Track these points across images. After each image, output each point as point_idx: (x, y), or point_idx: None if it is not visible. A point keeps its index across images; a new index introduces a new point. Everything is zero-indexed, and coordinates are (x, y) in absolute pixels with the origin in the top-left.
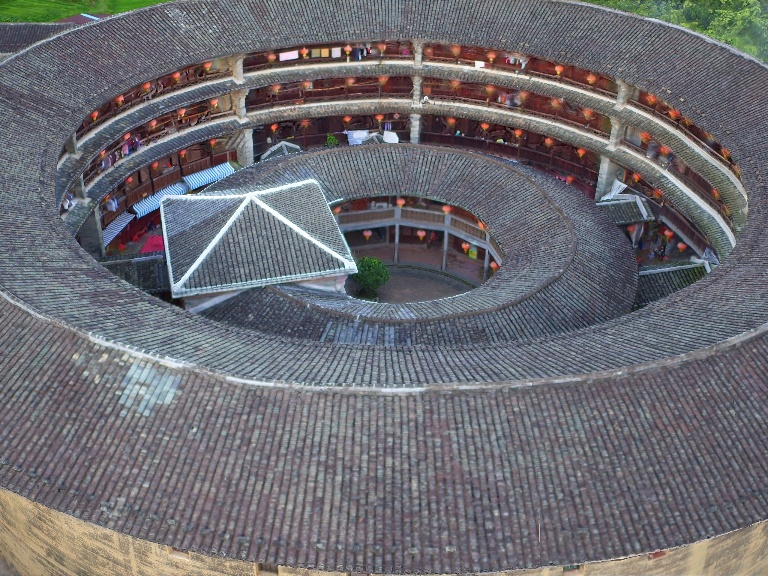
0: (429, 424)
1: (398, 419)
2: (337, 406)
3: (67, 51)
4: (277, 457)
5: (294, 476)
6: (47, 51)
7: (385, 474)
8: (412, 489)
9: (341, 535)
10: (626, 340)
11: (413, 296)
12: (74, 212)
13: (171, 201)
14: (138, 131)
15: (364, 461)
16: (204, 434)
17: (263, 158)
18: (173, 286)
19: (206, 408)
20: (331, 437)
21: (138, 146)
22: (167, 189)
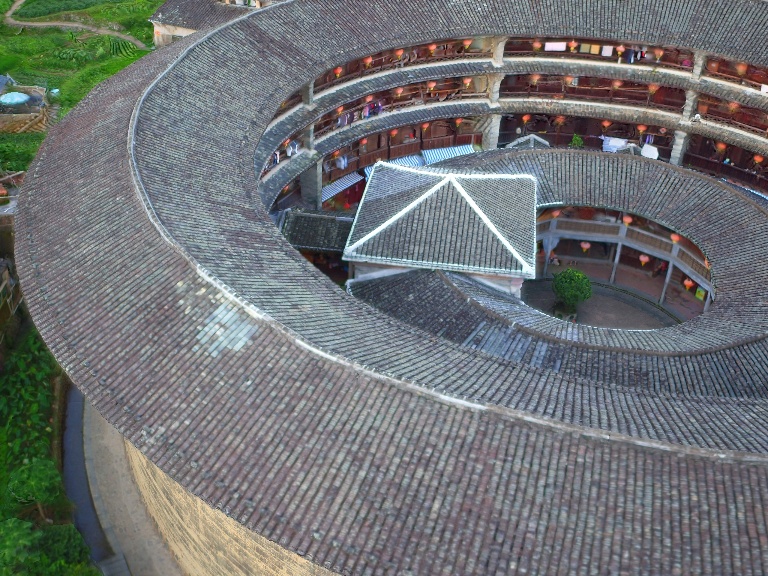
0: (477, 446)
1: (446, 431)
2: (389, 399)
3: (331, 7)
4: (312, 433)
5: (320, 457)
6: (312, 4)
7: (410, 484)
8: (432, 509)
9: (342, 532)
10: (767, 423)
11: (616, 322)
12: (297, 160)
13: (382, 168)
14: (384, 96)
15: (394, 464)
16: (255, 389)
17: (508, 147)
18: (346, 248)
19: (267, 364)
20: (371, 429)
21: (380, 111)
22: (403, 159)
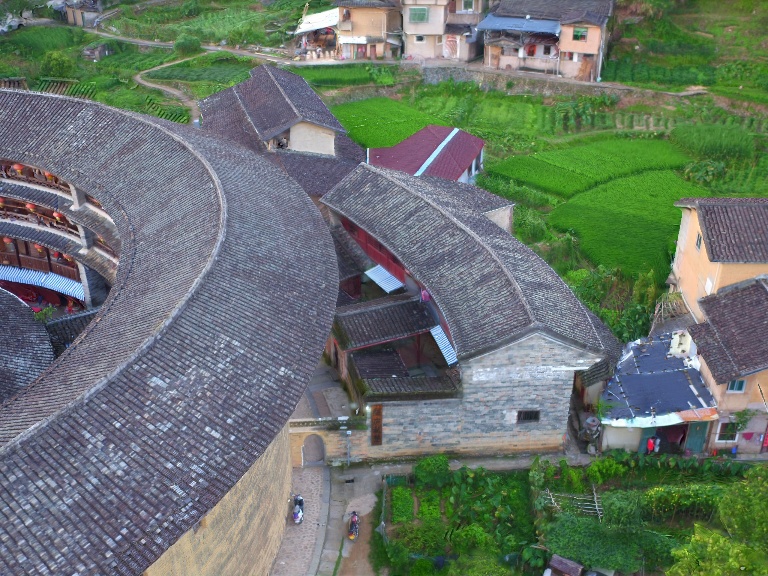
0: None
1: None
2: None
3: None
4: None
5: None
6: None
7: None
8: None
9: None
10: None
11: None
12: None
13: None
14: None
15: None
16: None
17: None
18: None
19: None
20: None
21: None
22: (39, 273)
